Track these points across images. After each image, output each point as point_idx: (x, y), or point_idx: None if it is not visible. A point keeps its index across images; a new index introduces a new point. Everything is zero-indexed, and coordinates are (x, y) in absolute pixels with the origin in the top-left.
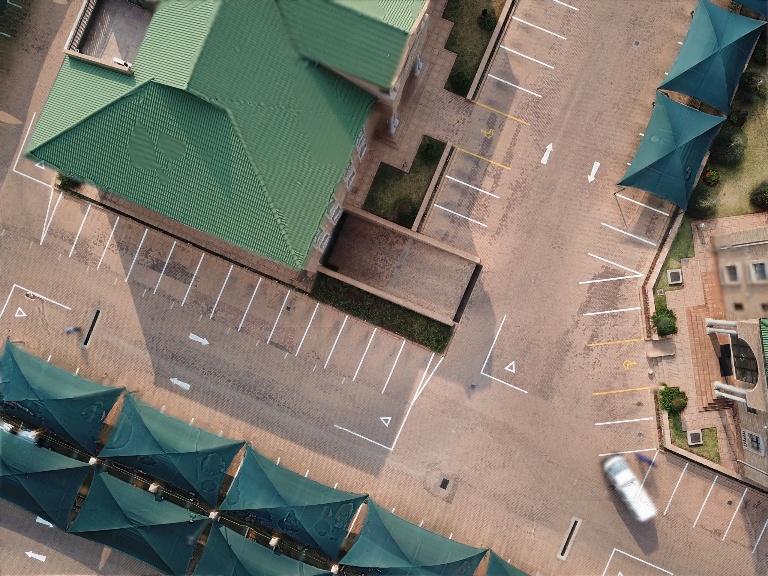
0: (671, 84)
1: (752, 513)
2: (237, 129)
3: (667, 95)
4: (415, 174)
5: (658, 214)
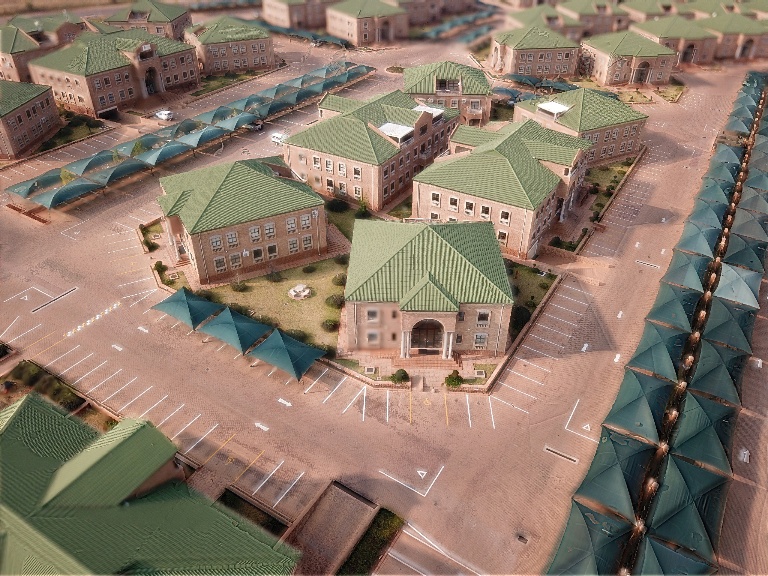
0: (244, 348)
1: (531, 357)
2: (150, 570)
3: (250, 352)
4: (242, 518)
5: (326, 374)
